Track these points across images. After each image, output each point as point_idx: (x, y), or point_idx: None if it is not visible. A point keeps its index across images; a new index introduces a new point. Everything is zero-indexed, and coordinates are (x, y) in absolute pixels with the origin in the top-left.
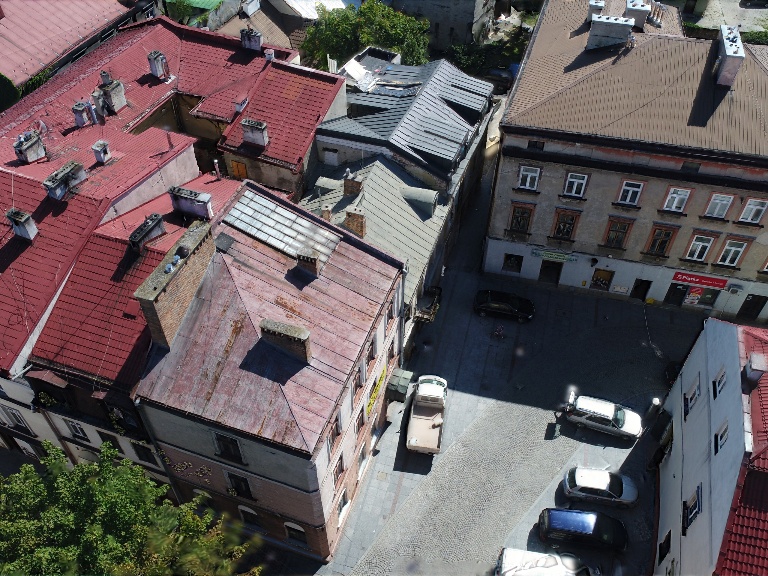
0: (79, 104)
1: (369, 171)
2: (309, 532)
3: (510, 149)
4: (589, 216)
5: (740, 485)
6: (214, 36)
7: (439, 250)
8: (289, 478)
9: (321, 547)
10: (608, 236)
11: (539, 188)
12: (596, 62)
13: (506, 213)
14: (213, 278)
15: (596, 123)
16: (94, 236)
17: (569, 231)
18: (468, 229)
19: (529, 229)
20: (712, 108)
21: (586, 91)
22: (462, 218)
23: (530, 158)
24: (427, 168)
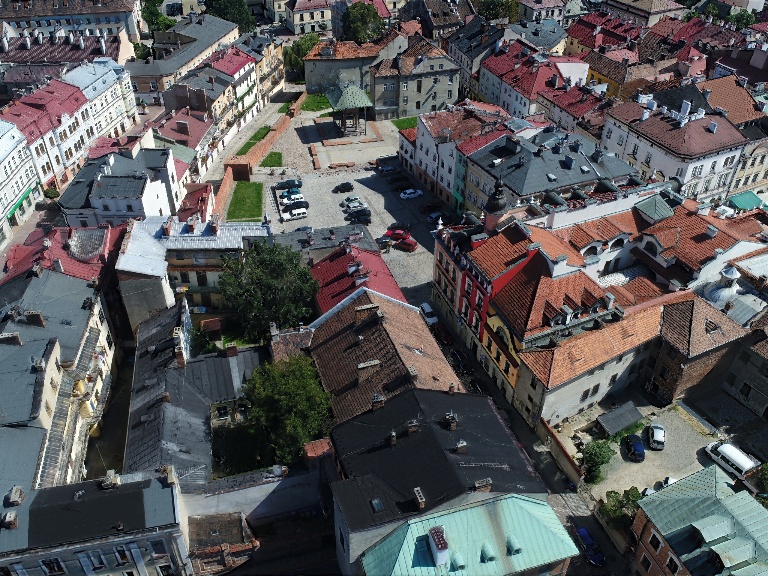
0: None
1: (578, 0)
2: None
3: None
4: None
5: (577, 19)
6: None
7: None
8: None
9: None
10: None
11: None
12: None
13: None
14: None
15: None
16: None
17: None
18: None
19: None
20: (638, 0)
21: None
22: None
23: None
24: None
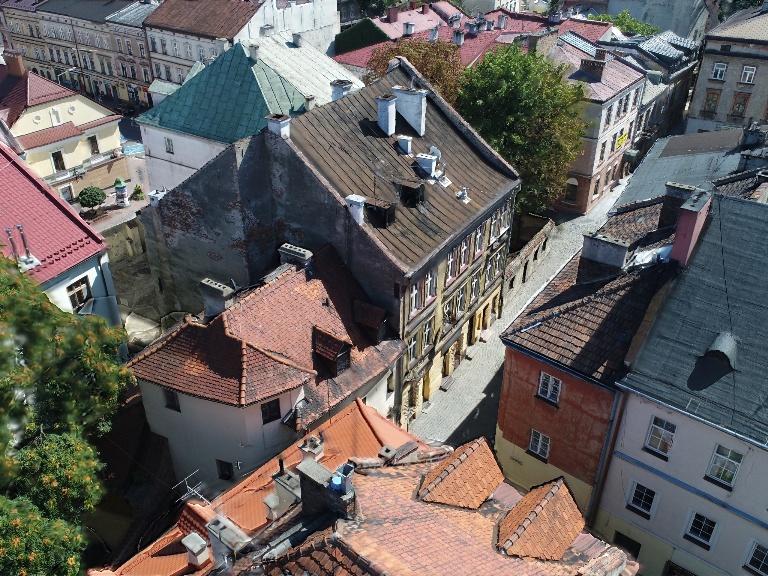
0: (469, 22)
1: None
2: (581, 184)
3: (710, 51)
4: (755, 97)
5: None
6: (532, 16)
7: (657, 117)
8: (584, 130)
9: (584, 200)
10: (767, 114)
11: (725, 78)
12: (766, 13)
13: (702, 98)
14: (555, 53)
15: (763, 36)
16: (493, 42)
17: (742, 112)
18: (673, 133)
19: (716, 109)
20: None
21: (759, 23)
22: (669, 126)
23: (721, 54)
24: (658, 62)
